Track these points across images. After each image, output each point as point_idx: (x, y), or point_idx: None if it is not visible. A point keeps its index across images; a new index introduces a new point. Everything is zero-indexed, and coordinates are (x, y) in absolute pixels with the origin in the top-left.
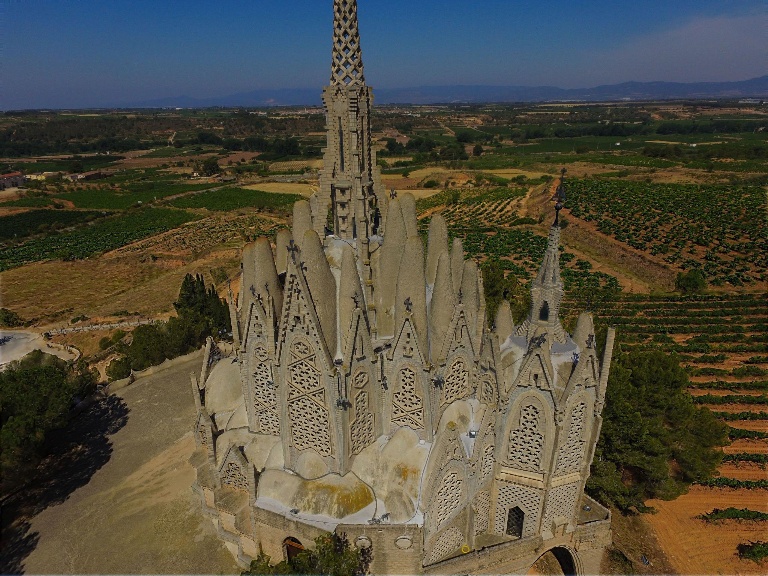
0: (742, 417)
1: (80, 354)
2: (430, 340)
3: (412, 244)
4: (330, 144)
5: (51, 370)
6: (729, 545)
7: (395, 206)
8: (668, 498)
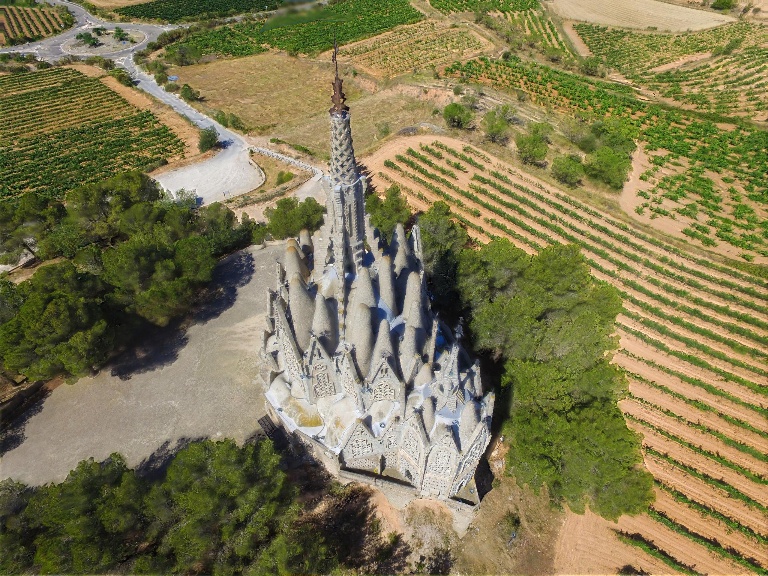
0: (765, 484)
1: (265, 180)
2: (372, 362)
3: (358, 311)
4: (328, 214)
5: (206, 244)
6: (619, 561)
7: (362, 274)
8: (573, 511)
